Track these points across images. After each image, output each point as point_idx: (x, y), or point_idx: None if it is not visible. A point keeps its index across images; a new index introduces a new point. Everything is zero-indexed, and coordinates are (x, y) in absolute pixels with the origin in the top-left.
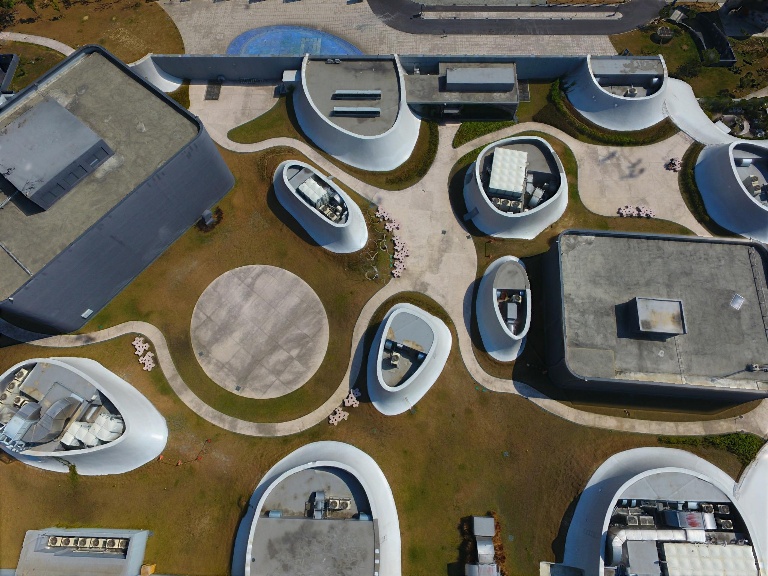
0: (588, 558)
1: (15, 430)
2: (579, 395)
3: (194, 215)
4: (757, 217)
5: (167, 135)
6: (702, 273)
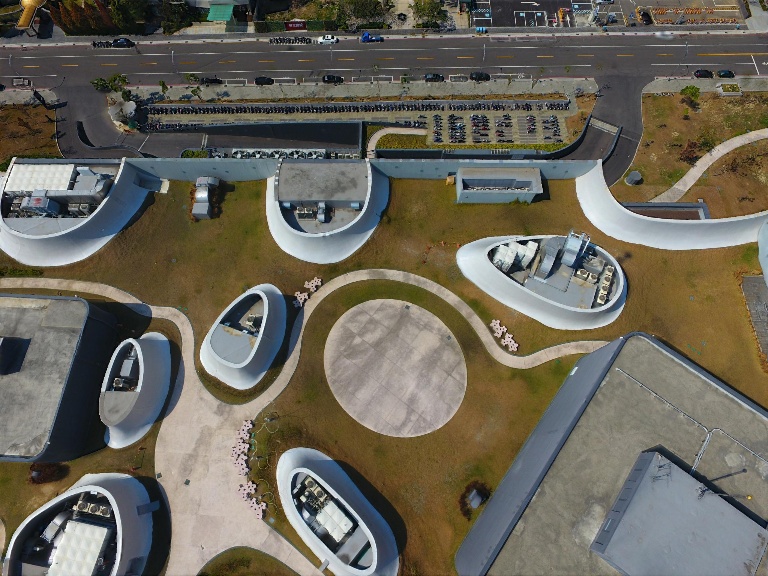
0: (127, 188)
1: (572, 241)
2: None
3: None
4: None
5: None
6: None
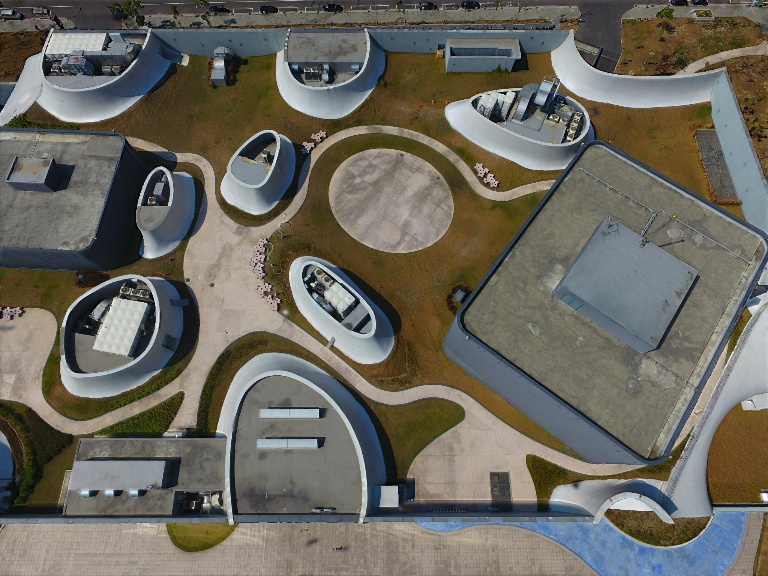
0: (153, 56)
1: (544, 84)
2: None
3: None
4: None
5: (500, 318)
6: None
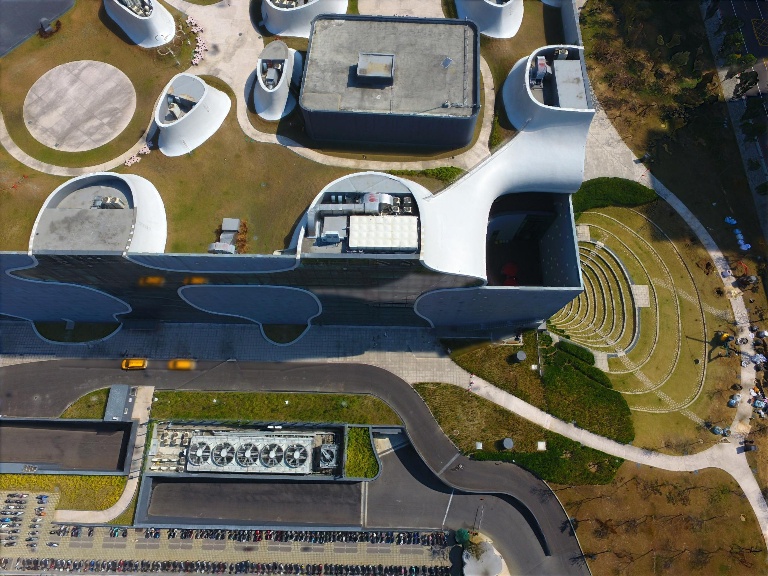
0: None
1: None
2: (329, 145)
3: (35, 23)
4: (488, 13)
5: None
6: (424, 44)
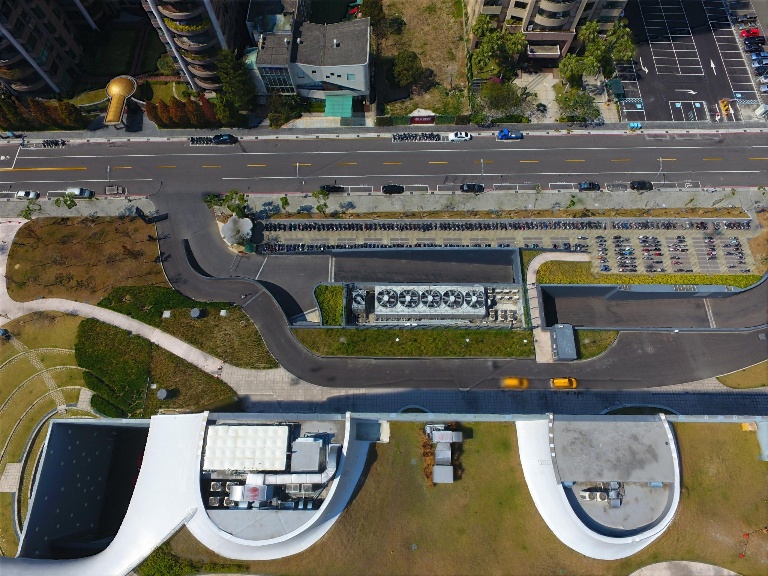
0: (352, 451)
1: None
2: None
3: None
4: None
5: None
6: None
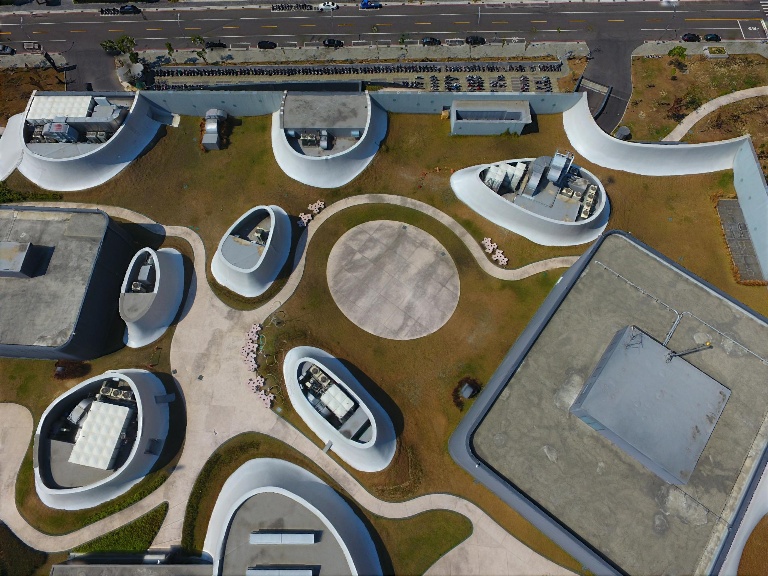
0: (141, 119)
1: (558, 159)
2: None
3: None
4: None
5: (512, 440)
6: None
